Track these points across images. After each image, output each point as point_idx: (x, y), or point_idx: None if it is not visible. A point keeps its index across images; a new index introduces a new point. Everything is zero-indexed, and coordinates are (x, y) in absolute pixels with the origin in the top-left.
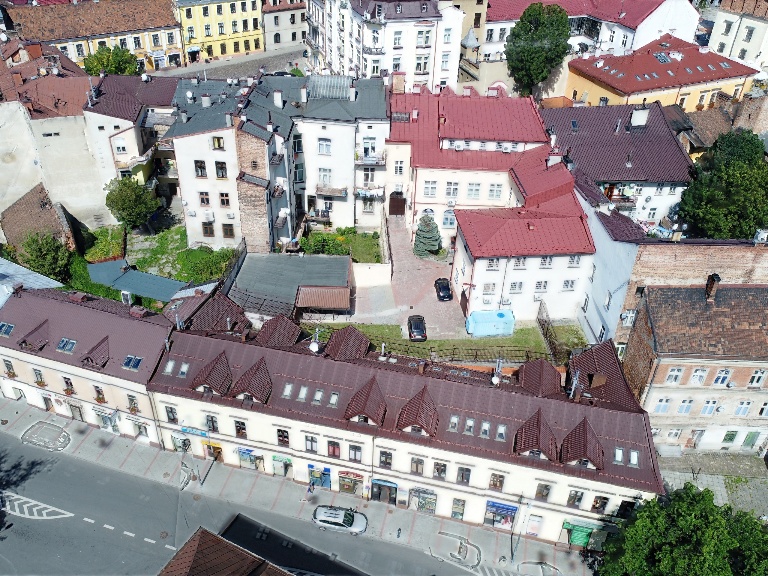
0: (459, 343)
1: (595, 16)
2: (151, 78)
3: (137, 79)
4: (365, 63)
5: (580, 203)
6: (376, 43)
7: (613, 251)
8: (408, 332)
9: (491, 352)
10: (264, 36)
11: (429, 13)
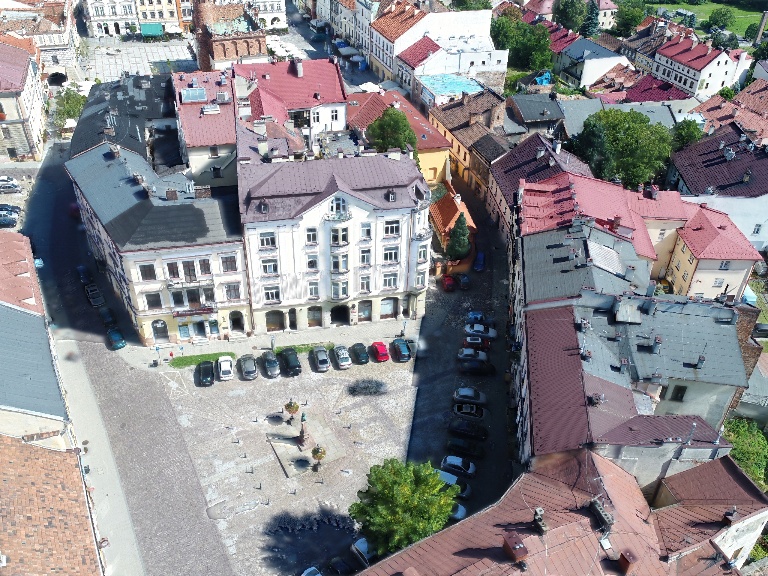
0: (760, 316)
1: (298, 108)
2: (589, 398)
3: (594, 412)
4: (423, 250)
5: (690, 202)
6: (417, 225)
7: (759, 203)
8: (759, 338)
9: (760, 305)
10: (58, 373)
11: None
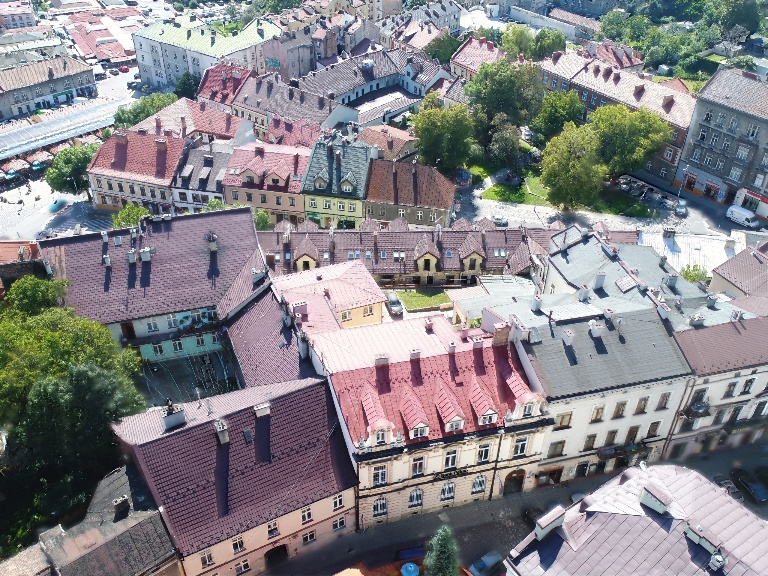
0: None
1: None
2: None
3: None
4: None
5: None
6: None
7: None
8: None
9: None
10: None
11: (574, 513)
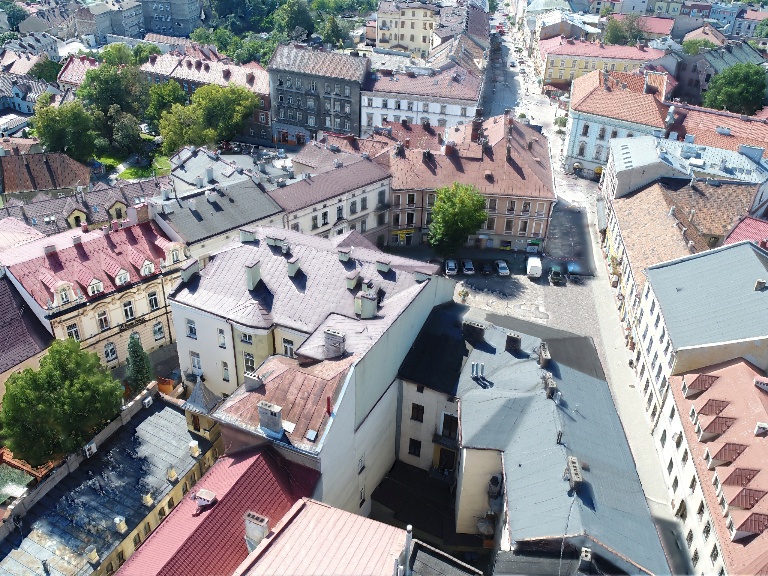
0: None
1: None
2: (339, 167)
3: None
4: None
5: None
6: None
7: None
8: None
9: None
10: None
11: None
